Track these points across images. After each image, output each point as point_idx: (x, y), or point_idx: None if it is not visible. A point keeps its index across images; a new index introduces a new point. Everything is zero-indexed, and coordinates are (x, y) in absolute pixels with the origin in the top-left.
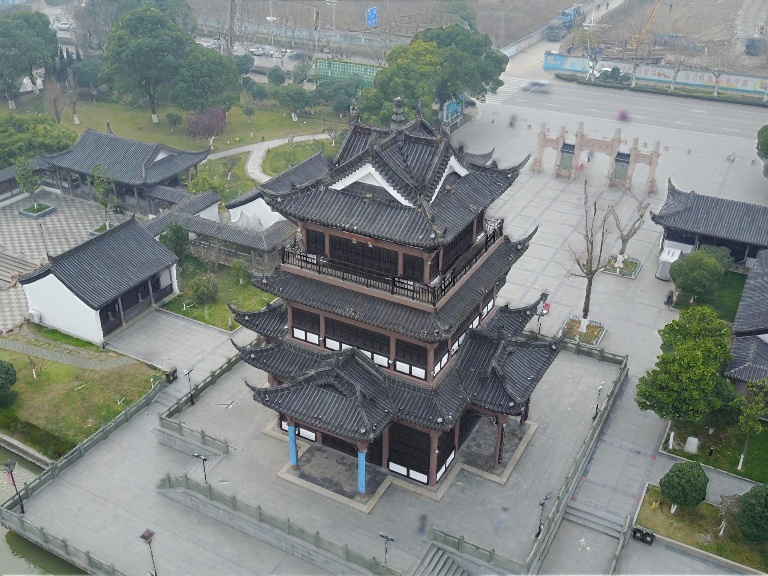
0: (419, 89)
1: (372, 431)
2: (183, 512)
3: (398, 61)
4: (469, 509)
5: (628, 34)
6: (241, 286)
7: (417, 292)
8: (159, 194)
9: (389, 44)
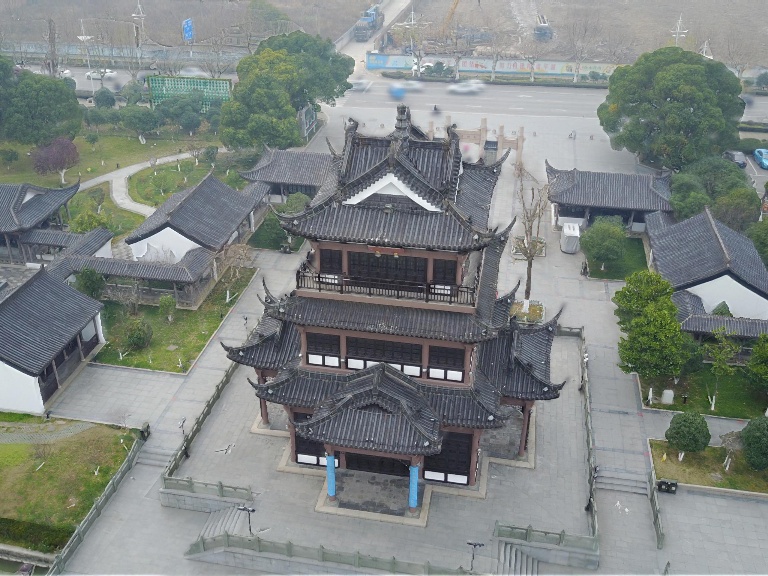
0: (282, 98)
1: (441, 442)
2: (227, 573)
3: (257, 71)
4: (515, 499)
5: (447, 30)
6: (172, 324)
7: (455, 296)
8: (39, 239)
9: (222, 55)
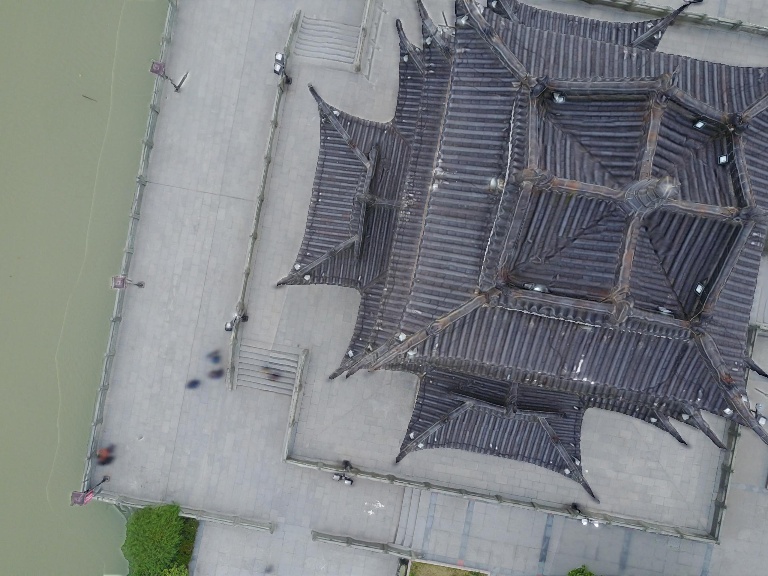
0: None
1: None
2: None
3: None
4: (362, 382)
5: None
6: None
7: None
8: None
9: None
